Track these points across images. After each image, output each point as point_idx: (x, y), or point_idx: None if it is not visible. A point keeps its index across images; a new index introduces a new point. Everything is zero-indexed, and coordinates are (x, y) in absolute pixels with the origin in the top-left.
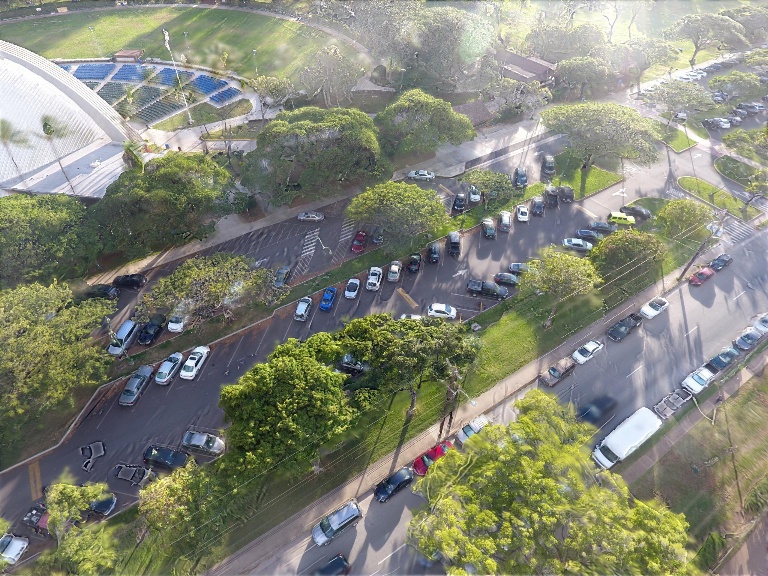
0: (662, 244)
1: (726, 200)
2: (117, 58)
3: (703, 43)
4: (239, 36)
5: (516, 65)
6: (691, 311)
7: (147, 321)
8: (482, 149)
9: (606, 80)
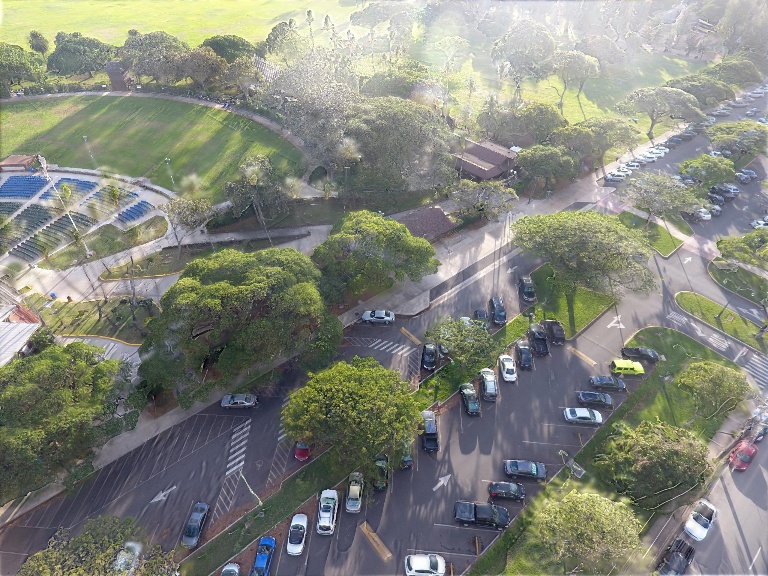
0: (708, 452)
1: (735, 323)
2: (3, 167)
3: (659, 116)
4: (155, 130)
5: (471, 154)
6: (745, 518)
7: None
8: (447, 269)
9: (573, 172)
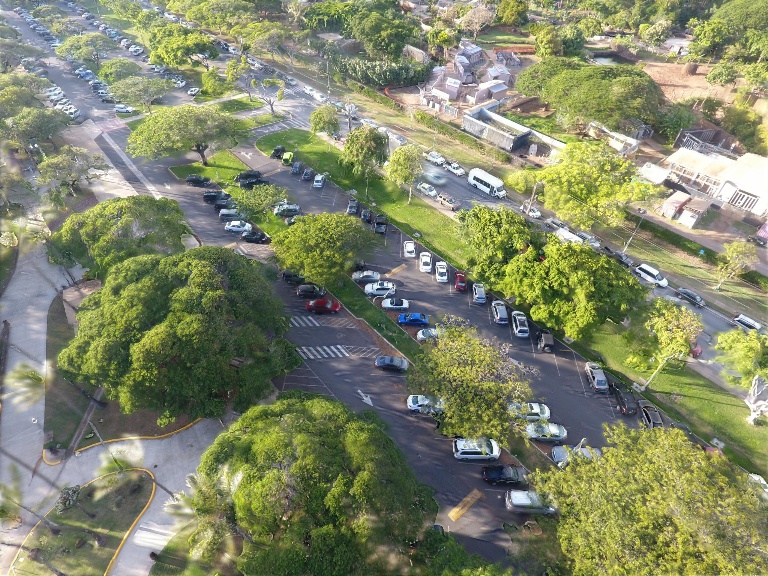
0: None
1: (262, 119)
2: None
3: (5, 66)
4: None
5: None
6: None
7: (545, 418)
8: None
9: None
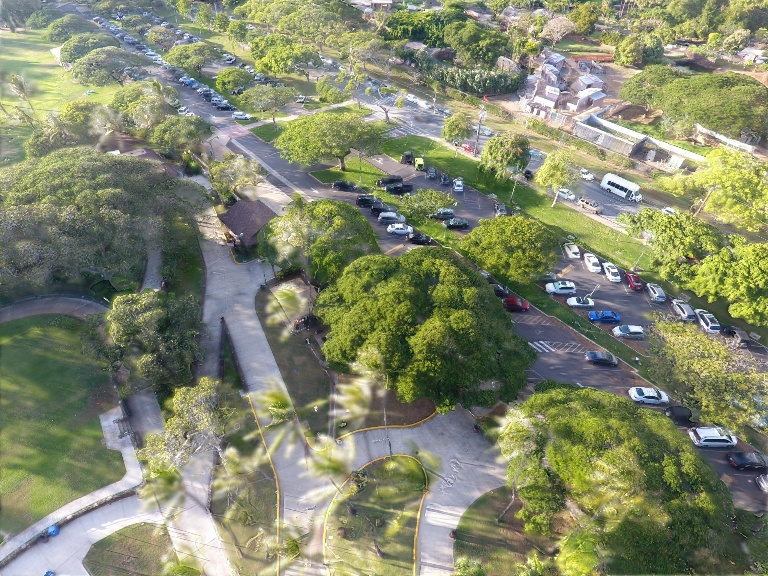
0: None
1: (377, 126)
2: None
3: (119, 75)
4: None
5: None
6: None
7: None
8: None
9: (211, 124)
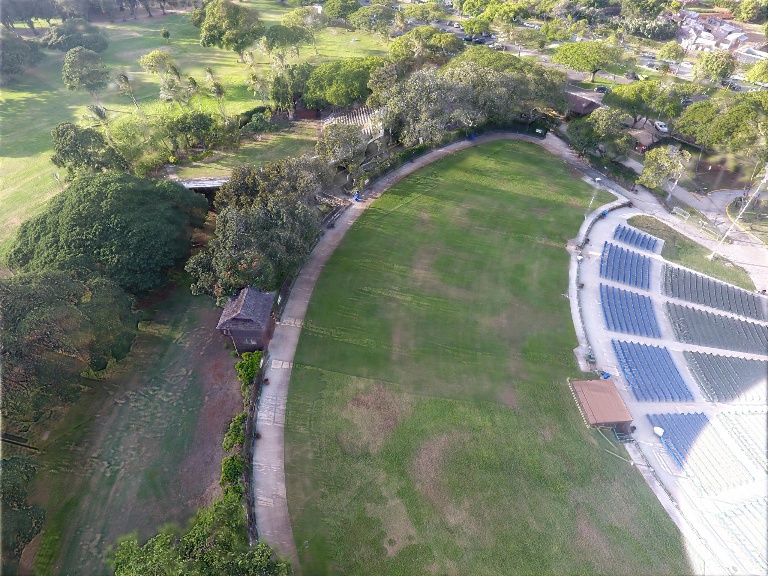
0: None
1: None
2: None
3: None
4: (445, 256)
5: None
6: None
7: None
8: None
9: None
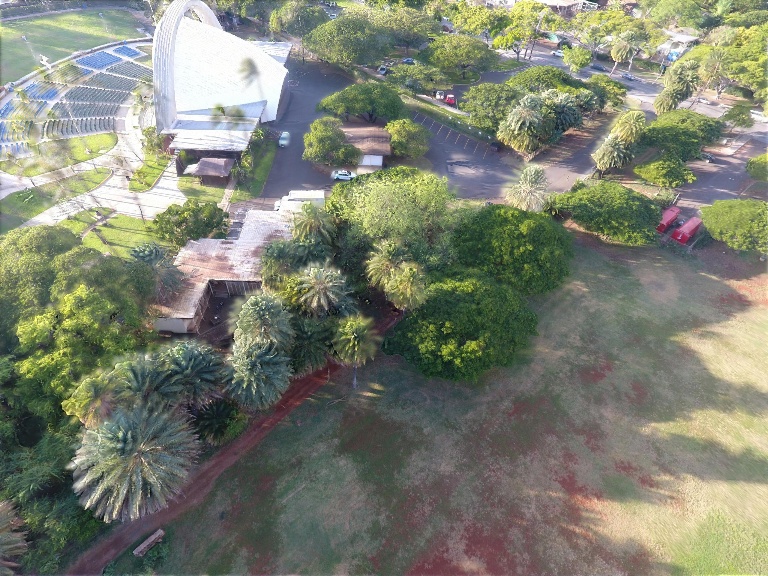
0: None
1: None
2: None
3: None
4: None
5: None
6: None
7: None
8: None
9: None
